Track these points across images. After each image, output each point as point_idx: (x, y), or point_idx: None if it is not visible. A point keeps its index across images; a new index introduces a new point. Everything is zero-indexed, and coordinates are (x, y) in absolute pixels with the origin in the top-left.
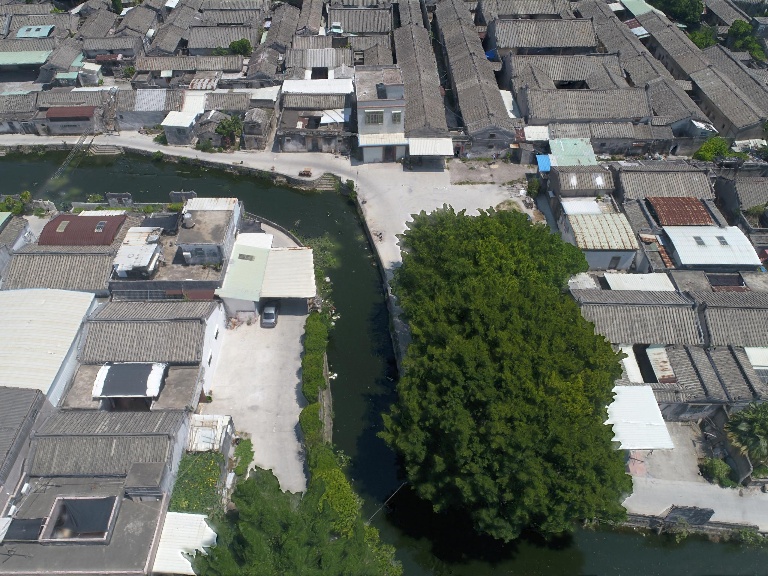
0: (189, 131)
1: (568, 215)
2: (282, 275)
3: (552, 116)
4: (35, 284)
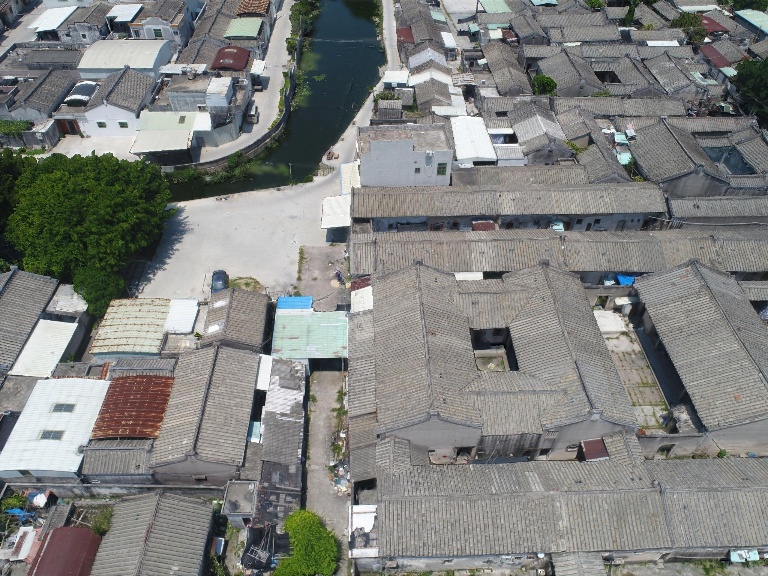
0: (386, 87)
1: (171, 300)
2: (160, 137)
3: (377, 302)
4: (182, 56)
